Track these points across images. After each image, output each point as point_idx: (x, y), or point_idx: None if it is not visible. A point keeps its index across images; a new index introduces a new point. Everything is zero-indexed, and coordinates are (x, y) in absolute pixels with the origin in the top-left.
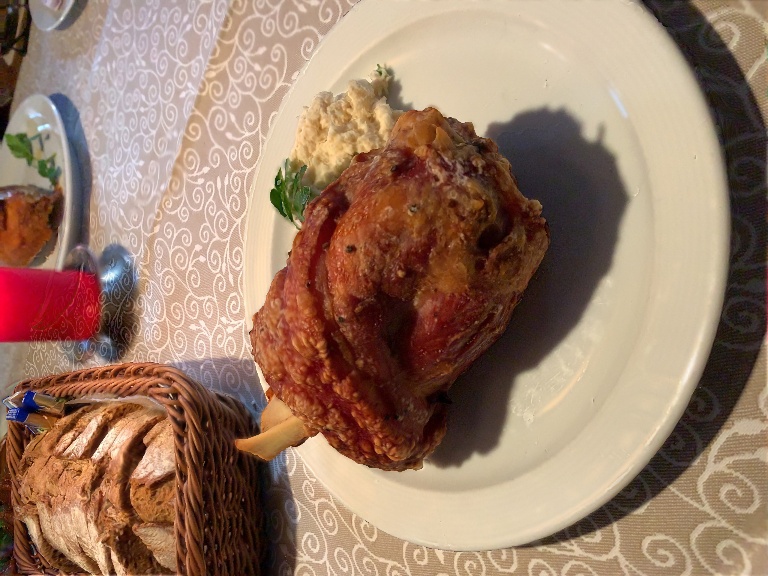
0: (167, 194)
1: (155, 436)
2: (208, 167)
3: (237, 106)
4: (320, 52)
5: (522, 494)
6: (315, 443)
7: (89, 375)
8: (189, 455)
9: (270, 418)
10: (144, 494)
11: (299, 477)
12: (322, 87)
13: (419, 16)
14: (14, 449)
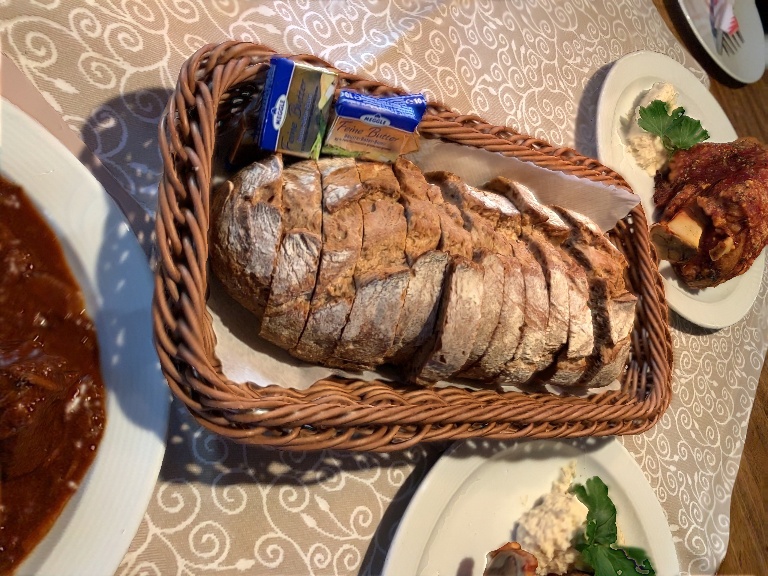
0: (456, 1)
1: None
2: (501, 22)
3: (534, 6)
4: (645, 55)
5: (732, 304)
6: None
7: None
8: None
9: (689, 240)
10: None
11: None
12: (640, 72)
13: (681, 87)
14: None
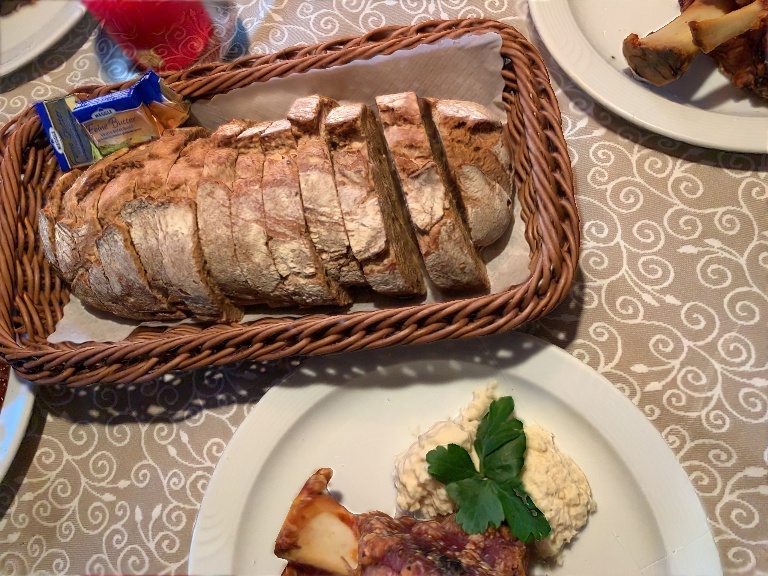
0: None
1: (436, 101)
2: None
3: None
4: None
5: None
6: (651, 104)
7: (280, 58)
8: (549, 84)
9: (666, 42)
10: (463, 135)
11: (584, 167)
12: None
13: None
14: (12, 189)
